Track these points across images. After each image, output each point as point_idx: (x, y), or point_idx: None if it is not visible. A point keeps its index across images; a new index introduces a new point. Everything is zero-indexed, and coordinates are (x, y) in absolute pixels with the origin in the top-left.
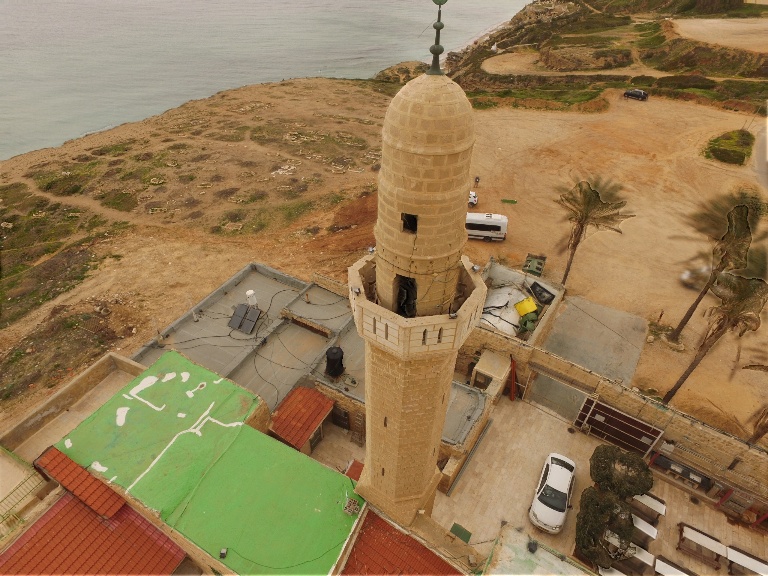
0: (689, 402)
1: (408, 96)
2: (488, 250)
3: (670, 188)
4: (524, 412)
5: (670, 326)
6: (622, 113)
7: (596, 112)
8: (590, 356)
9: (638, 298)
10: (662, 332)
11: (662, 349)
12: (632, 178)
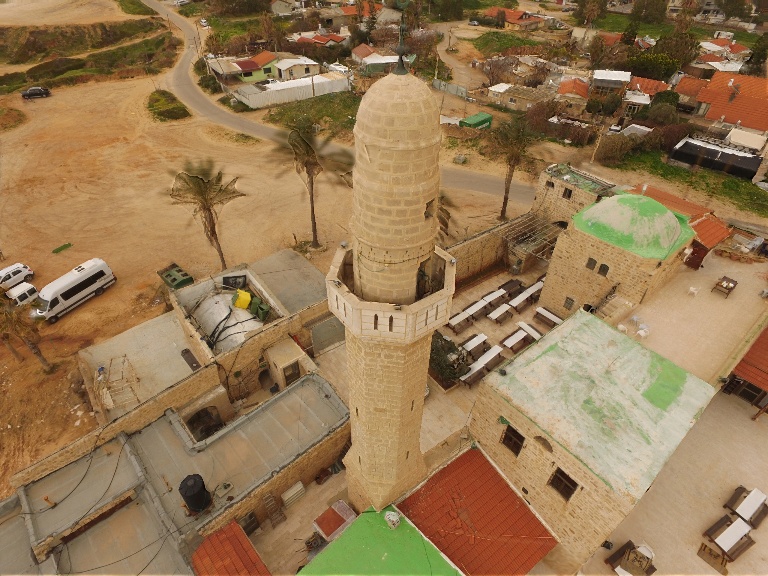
0: None
1: (411, 98)
2: (114, 299)
3: (171, 157)
4: (326, 362)
5: (301, 241)
6: (46, 115)
7: (19, 124)
8: (301, 295)
9: (263, 241)
10: (305, 248)
11: (320, 256)
12: (135, 164)
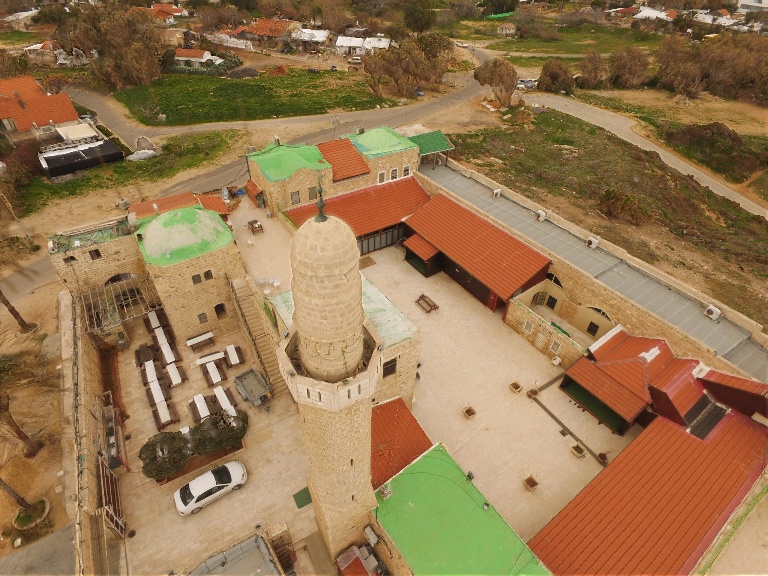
0: (2, 502)
1: None
2: None
3: None
4: None
5: None
6: None
7: None
8: None
9: None
10: None
11: None
12: None
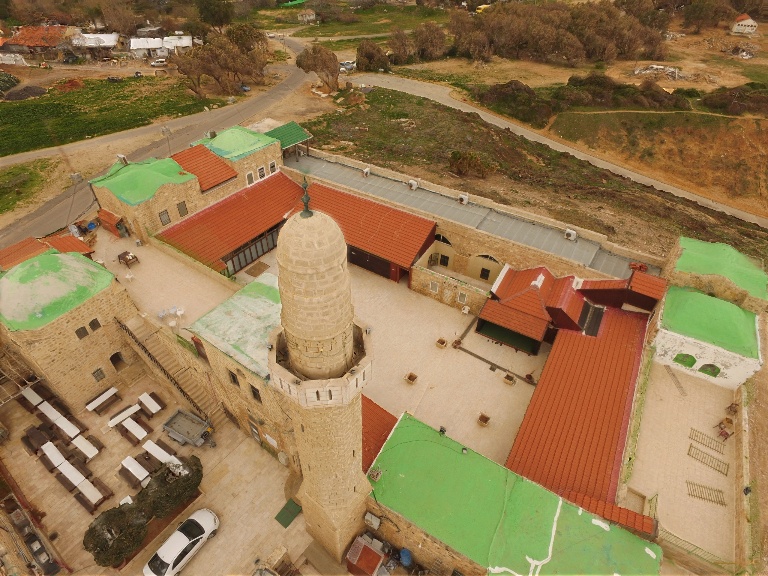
0: None
1: None
2: None
3: None
4: None
5: None
6: None
7: None
8: None
9: None
10: None
11: None
12: None
